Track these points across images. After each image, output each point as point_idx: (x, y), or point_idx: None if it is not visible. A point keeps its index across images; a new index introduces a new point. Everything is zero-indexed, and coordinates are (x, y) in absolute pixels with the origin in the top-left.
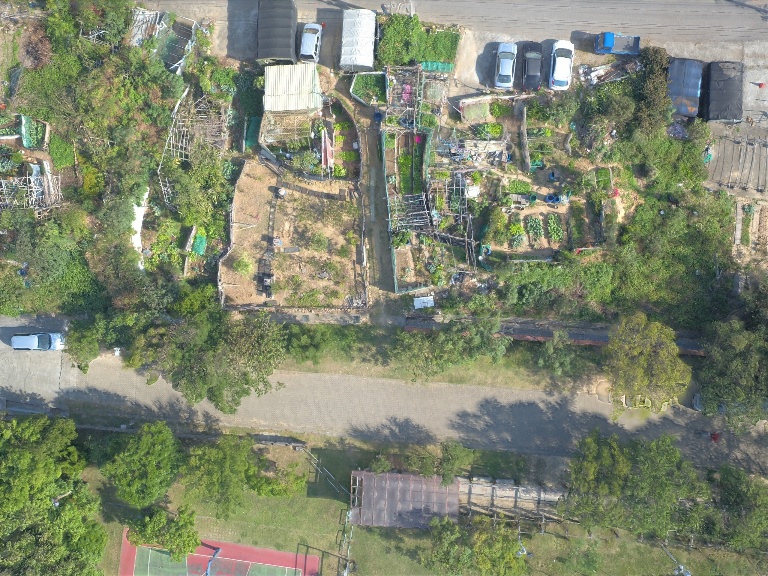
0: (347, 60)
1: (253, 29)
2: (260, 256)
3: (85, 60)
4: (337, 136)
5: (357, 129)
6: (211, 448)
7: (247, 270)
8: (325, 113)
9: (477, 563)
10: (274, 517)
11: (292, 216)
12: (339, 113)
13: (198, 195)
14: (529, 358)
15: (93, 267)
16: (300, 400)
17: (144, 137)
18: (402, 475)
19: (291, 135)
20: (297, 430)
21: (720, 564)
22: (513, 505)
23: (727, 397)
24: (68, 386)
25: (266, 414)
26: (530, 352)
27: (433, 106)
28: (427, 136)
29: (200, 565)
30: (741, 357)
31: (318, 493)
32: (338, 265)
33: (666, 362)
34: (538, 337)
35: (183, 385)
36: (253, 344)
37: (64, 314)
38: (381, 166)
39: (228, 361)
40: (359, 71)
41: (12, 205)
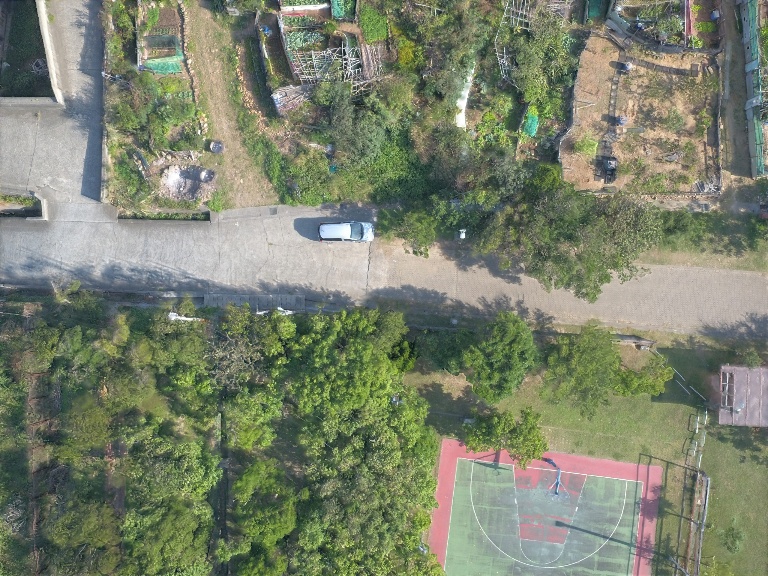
0: None
1: None
2: (599, 137)
3: None
4: (692, 5)
5: None
6: None
7: (593, 150)
8: None
9: None
10: (614, 424)
11: (636, 94)
12: None
13: (534, 69)
14: None
15: (419, 146)
16: (644, 295)
17: (473, 6)
18: None
19: None
20: (640, 328)
21: None
22: None
23: None
24: (378, 282)
25: (605, 311)
26: None
27: None
28: None
29: (530, 479)
30: None
31: (664, 397)
32: (689, 146)
33: None
34: None
35: (548, 267)
36: (628, 222)
37: (373, 203)
38: (739, 38)
39: None
40: None
41: (323, 79)
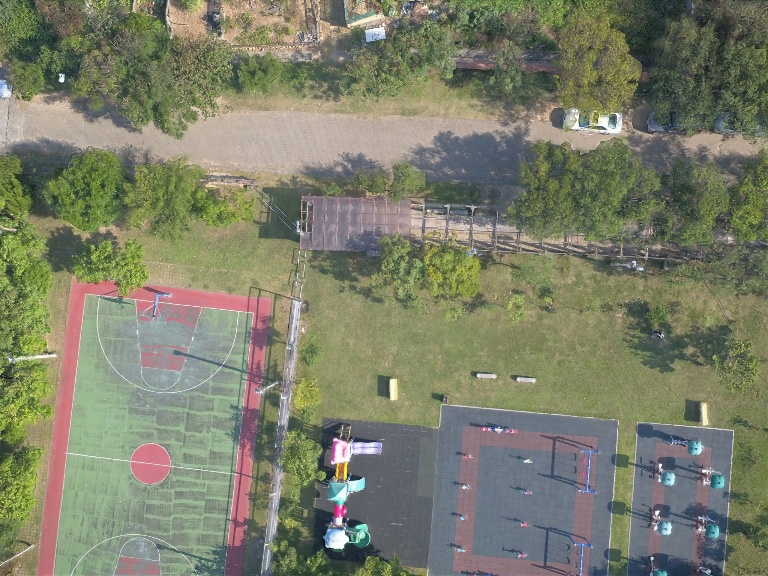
0: None
1: None
2: None
3: None
4: None
5: None
6: None
7: (195, 3)
8: None
9: (428, 275)
10: (225, 260)
11: None
12: None
13: None
14: (482, 87)
15: (39, 5)
16: (251, 139)
17: None
18: (353, 198)
19: None
20: (248, 170)
21: (678, 290)
22: (468, 237)
23: (678, 91)
24: (15, 135)
25: (216, 155)
26: (483, 81)
27: None
28: None
29: (150, 312)
30: (691, 47)
31: (270, 233)
32: None
33: (616, 56)
34: (491, 64)
35: (128, 102)
36: (199, 58)
37: None
38: None
39: (174, 77)
40: None
41: None
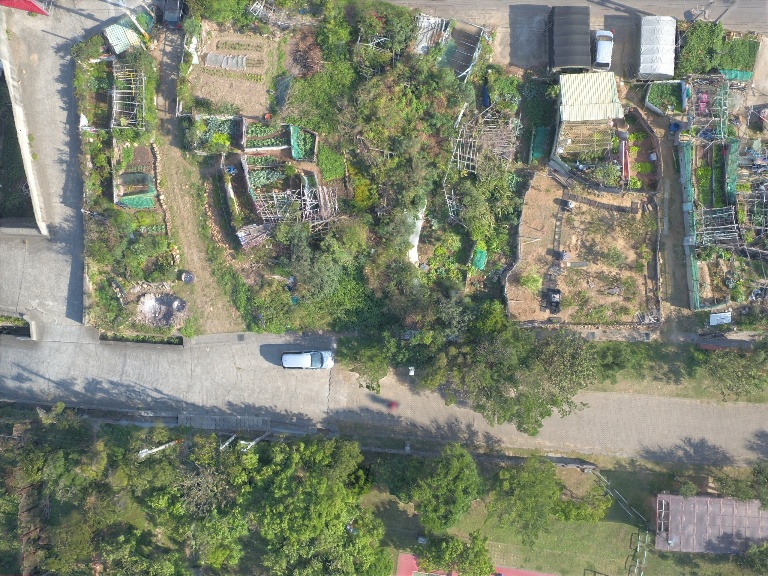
0: (647, 68)
1: (537, 36)
2: (545, 271)
3: (362, 68)
4: (631, 147)
5: (656, 140)
6: (520, 472)
7: (537, 286)
8: (616, 123)
9: None
10: (560, 541)
11: (579, 229)
12: (632, 123)
13: (482, 208)
14: None
15: (373, 283)
16: (588, 420)
17: (424, 148)
18: (712, 499)
19: (590, 146)
20: (584, 451)
21: None
22: None
23: None
24: (338, 406)
25: (551, 435)
26: None
27: (730, 116)
28: (730, 147)
29: None
30: None
31: (607, 516)
32: (630, 280)
33: None
34: None
35: (490, 406)
36: (565, 363)
37: (333, 331)
38: (677, 178)
39: None
40: (655, 80)
41: (284, 218)
